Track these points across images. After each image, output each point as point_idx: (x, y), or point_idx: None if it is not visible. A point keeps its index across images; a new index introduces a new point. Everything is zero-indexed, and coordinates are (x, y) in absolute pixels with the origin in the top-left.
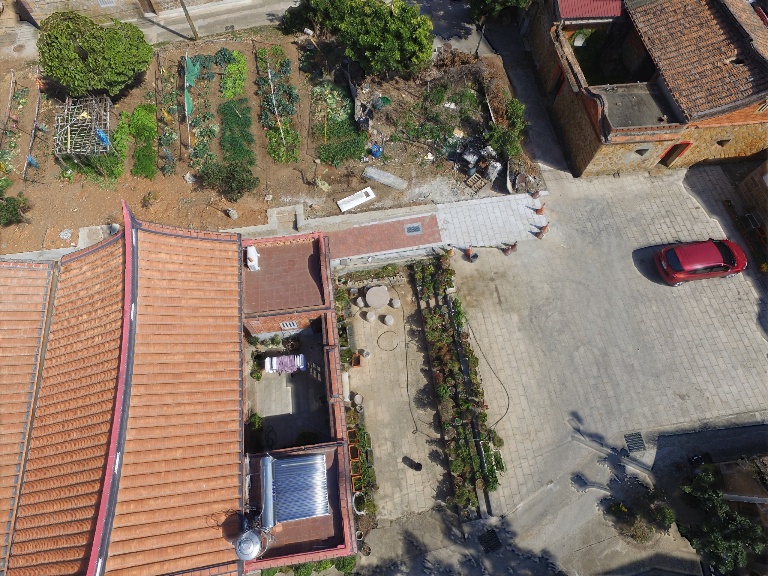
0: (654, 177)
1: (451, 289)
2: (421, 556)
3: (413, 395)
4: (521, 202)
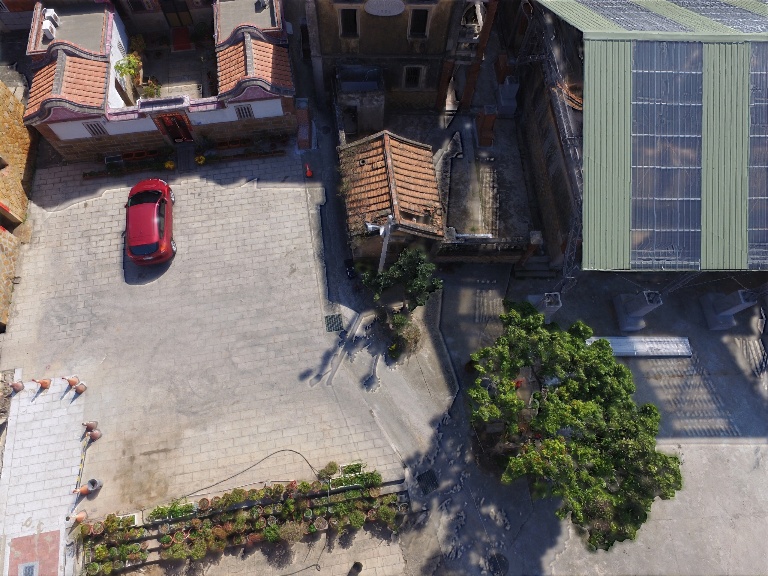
0: (32, 239)
1: (136, 519)
2: (446, 562)
3: (274, 570)
4: (24, 407)
